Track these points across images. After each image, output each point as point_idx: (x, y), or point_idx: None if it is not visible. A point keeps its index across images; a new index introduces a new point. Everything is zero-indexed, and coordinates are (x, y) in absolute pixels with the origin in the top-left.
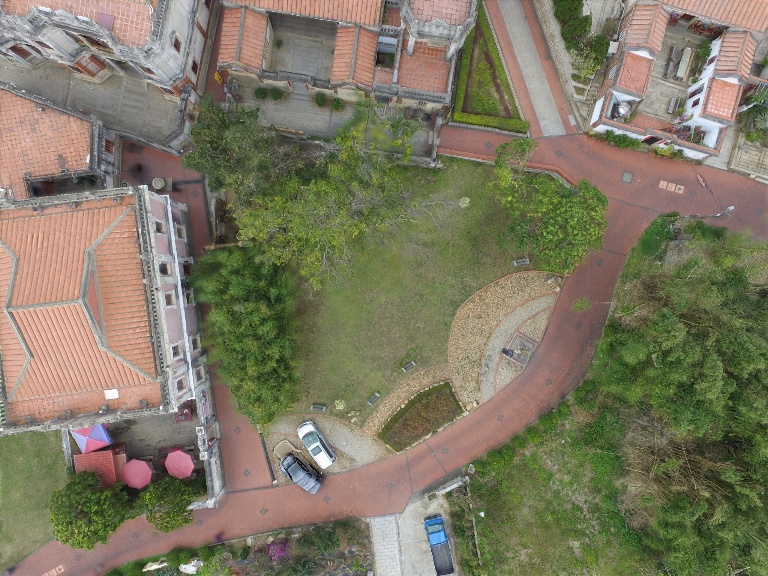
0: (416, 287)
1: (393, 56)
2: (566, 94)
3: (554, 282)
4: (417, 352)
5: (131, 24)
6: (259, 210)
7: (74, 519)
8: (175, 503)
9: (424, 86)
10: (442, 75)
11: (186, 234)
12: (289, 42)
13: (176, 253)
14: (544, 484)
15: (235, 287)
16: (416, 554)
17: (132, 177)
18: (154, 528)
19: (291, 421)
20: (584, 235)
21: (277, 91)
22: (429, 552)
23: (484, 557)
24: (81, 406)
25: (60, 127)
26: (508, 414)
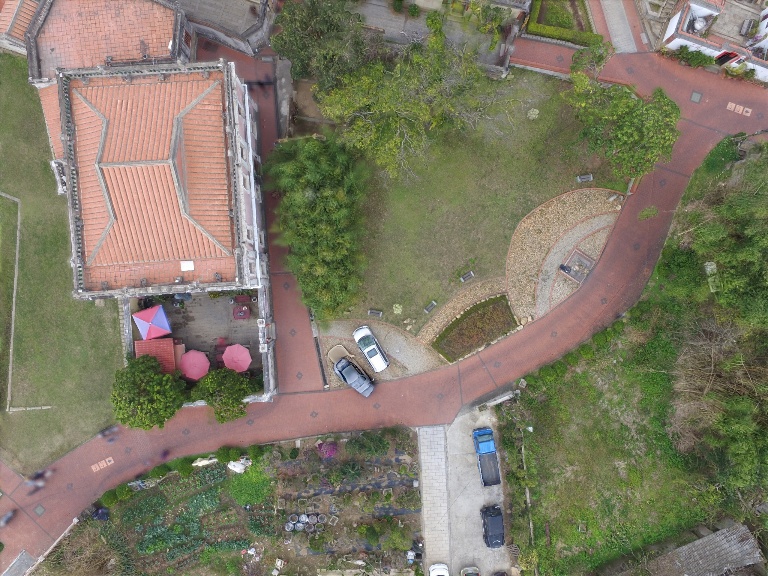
0: (479, 198)
1: None
2: (639, 13)
3: (615, 201)
4: (476, 263)
5: None
6: (345, 88)
7: (138, 395)
8: (235, 390)
9: None
10: None
11: (256, 131)
12: None
13: (250, 142)
14: (594, 403)
15: (312, 171)
16: (462, 466)
17: None
18: (205, 425)
19: (347, 326)
20: (659, 138)
21: None
22: (475, 465)
23: (530, 472)
24: (157, 276)
25: (143, 13)
26: (562, 331)
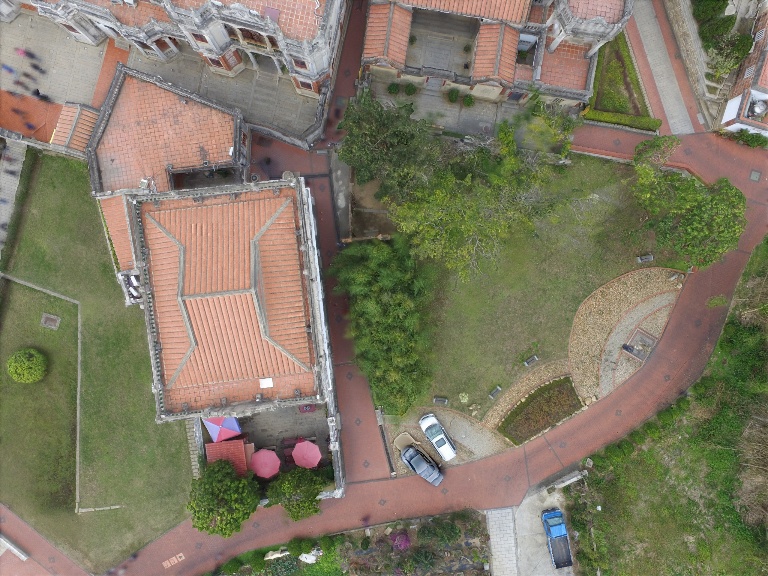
0: (539, 282)
1: (524, 53)
2: (695, 93)
3: (676, 279)
4: (538, 347)
5: (296, 18)
6: (420, 203)
7: (216, 506)
8: (310, 492)
9: (564, 83)
10: (581, 72)
11: (316, 227)
12: (421, 38)
13: (315, 245)
14: (661, 479)
15: (384, 279)
16: (532, 547)
17: (261, 170)
18: (274, 517)
19: (412, 413)
20: (730, 232)
21: (413, 87)
22: (544, 545)
23: (600, 550)
24: (236, 394)
25: (202, 120)
26: (626, 409)
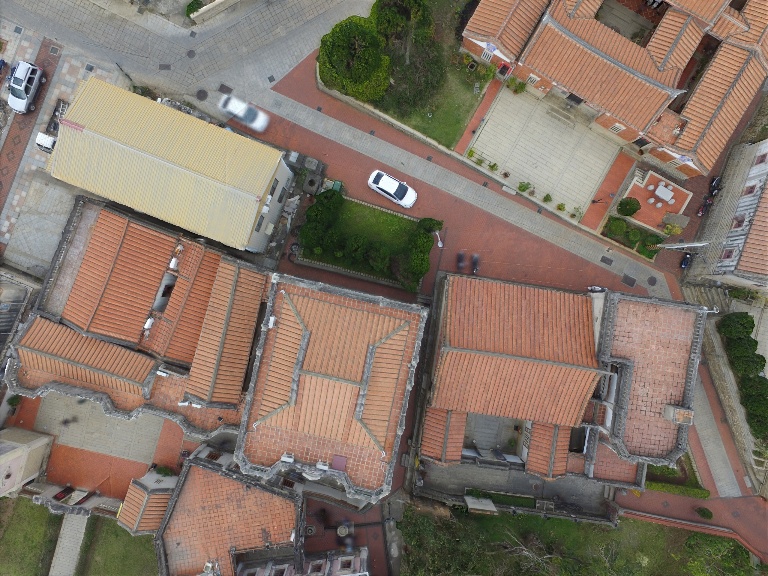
0: None
1: None
2: (741, 456)
3: None
4: None
5: (362, 464)
6: None
7: None
8: None
9: (615, 473)
10: None
11: None
12: None
13: None
14: None
15: None
16: None
17: (316, 521)
18: None
19: None
20: None
21: None
22: None
23: None
24: None
25: (264, 503)
26: None
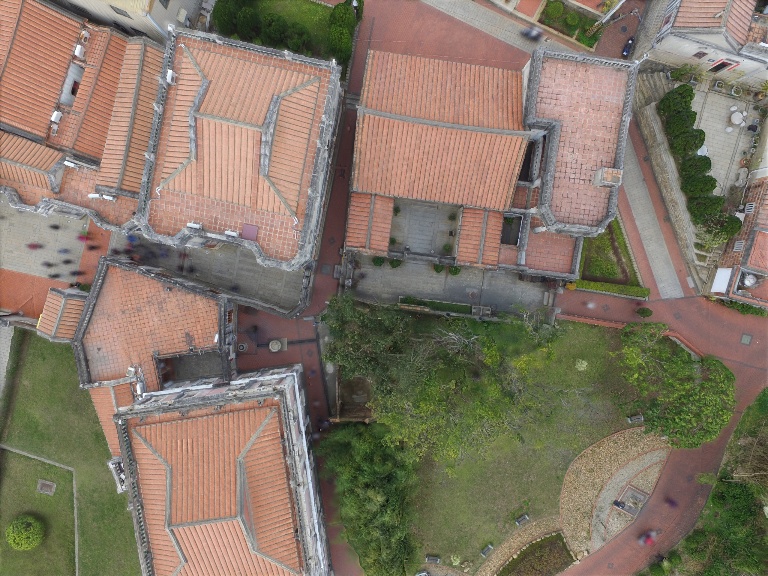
0: (529, 443)
1: (510, 220)
2: (684, 256)
3: (667, 437)
4: (529, 505)
5: (274, 233)
6: (404, 416)
7: None
8: None
9: (549, 263)
10: (567, 252)
11: (304, 397)
12: (405, 207)
13: (303, 429)
14: None
15: (371, 476)
16: None
17: (248, 338)
18: None
19: None
20: (718, 423)
21: (397, 262)
22: None
23: None
24: None
25: (186, 306)
26: (618, 562)
